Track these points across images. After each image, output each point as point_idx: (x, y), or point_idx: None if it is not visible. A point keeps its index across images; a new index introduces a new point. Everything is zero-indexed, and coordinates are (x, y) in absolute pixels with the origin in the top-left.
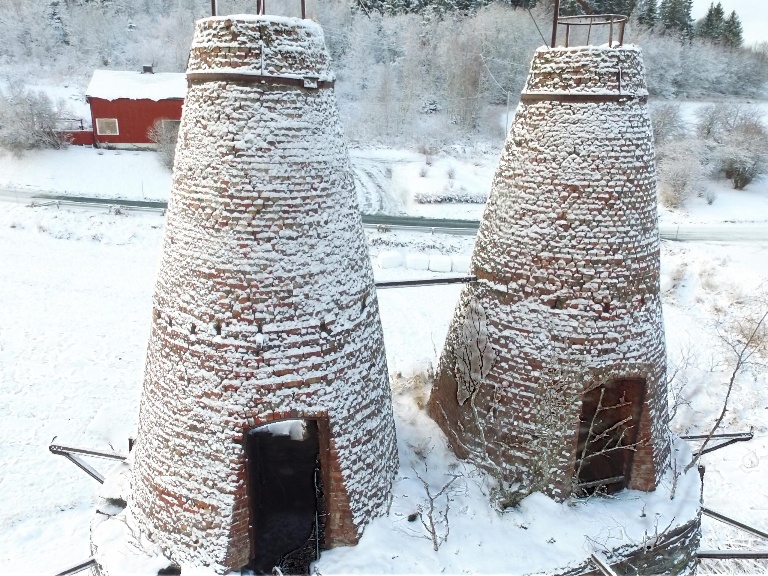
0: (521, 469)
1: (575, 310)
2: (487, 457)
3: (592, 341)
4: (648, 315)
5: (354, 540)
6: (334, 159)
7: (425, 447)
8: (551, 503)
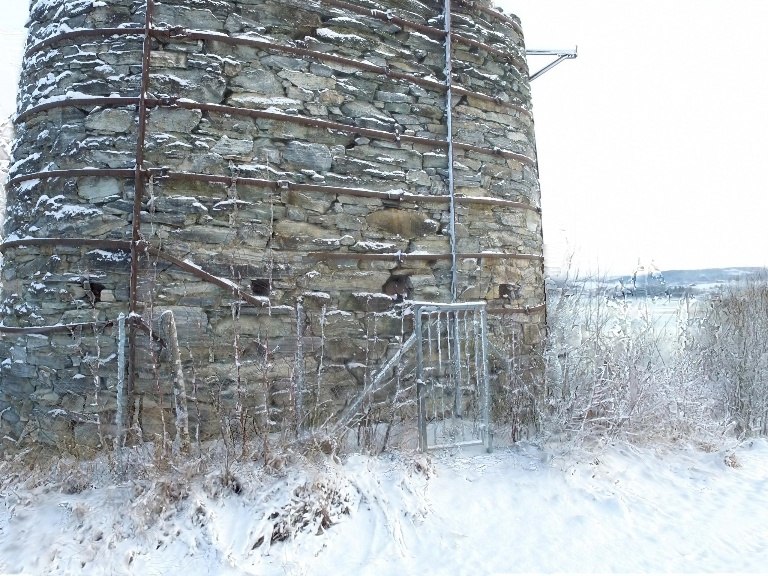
0: None
1: None
2: None
3: None
4: None
5: None
6: None
7: None
8: None
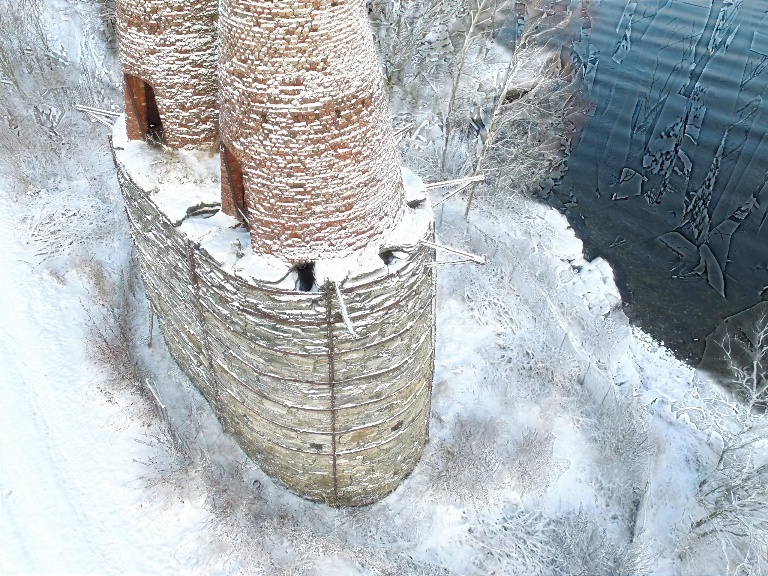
0: None
1: None
2: None
3: None
4: None
5: None
6: None
7: None
8: None
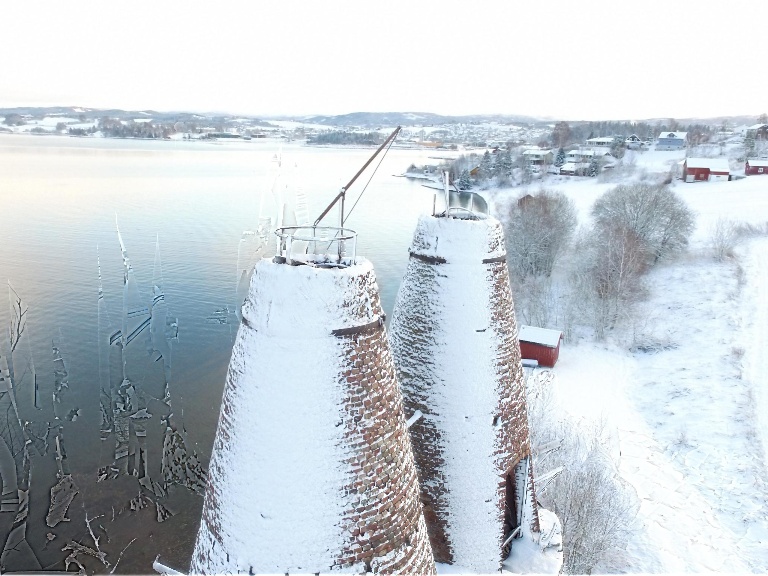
0: None
1: None
2: None
3: None
4: None
5: None
6: None
7: None
8: None
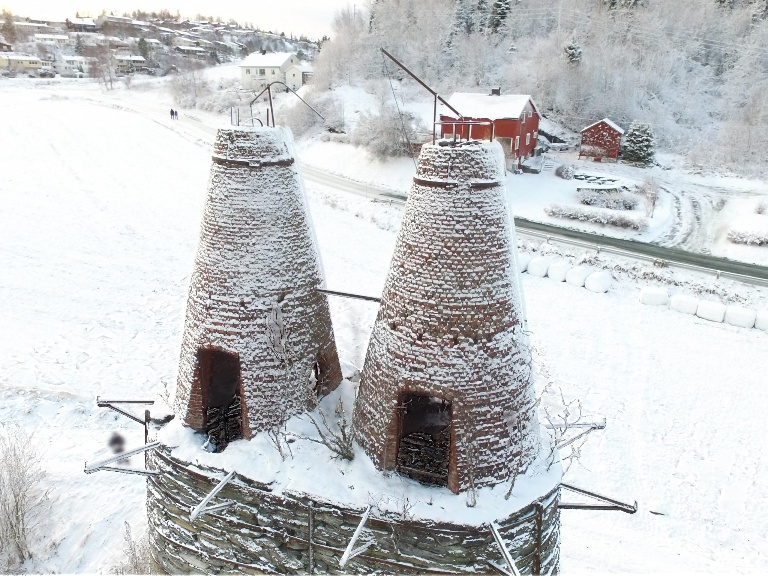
0: (364, 438)
1: (401, 334)
2: (305, 409)
3: (407, 359)
4: (462, 353)
5: (250, 437)
6: (268, 208)
7: (340, 409)
8: (372, 467)
